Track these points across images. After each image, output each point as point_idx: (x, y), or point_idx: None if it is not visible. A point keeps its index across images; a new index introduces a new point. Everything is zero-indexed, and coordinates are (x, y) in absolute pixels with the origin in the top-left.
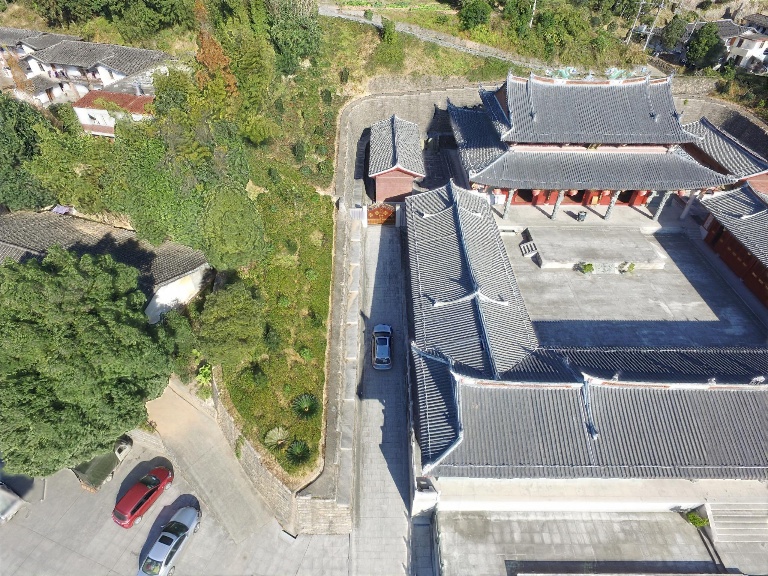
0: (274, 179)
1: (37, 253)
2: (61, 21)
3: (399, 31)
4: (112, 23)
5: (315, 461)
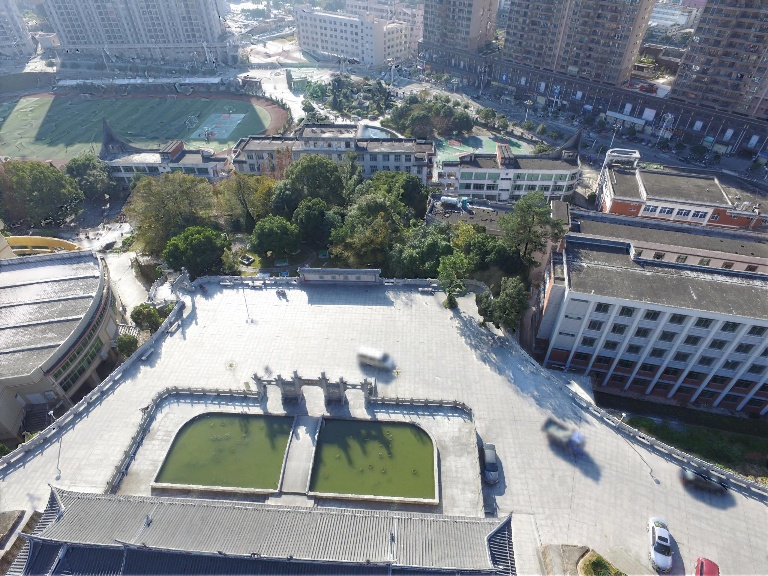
0: None
1: None
2: None
3: None
4: None
5: (586, 572)
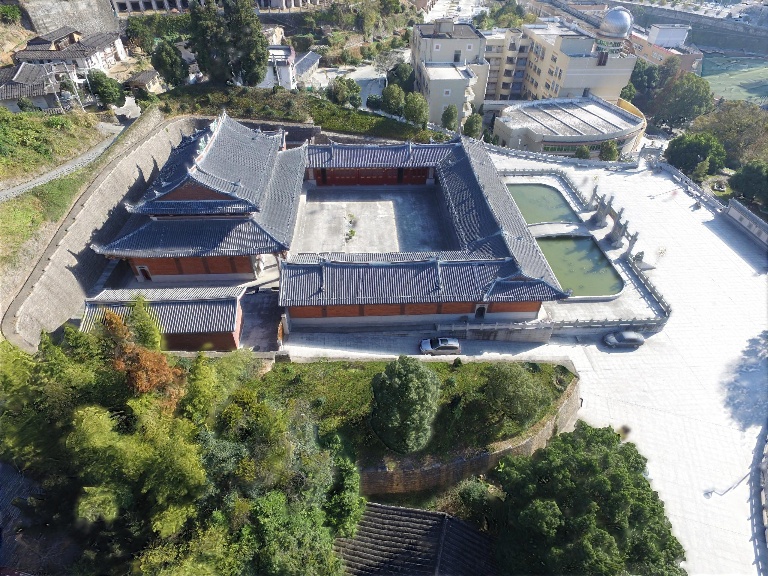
0: None
1: None
2: None
3: None
4: None
5: None
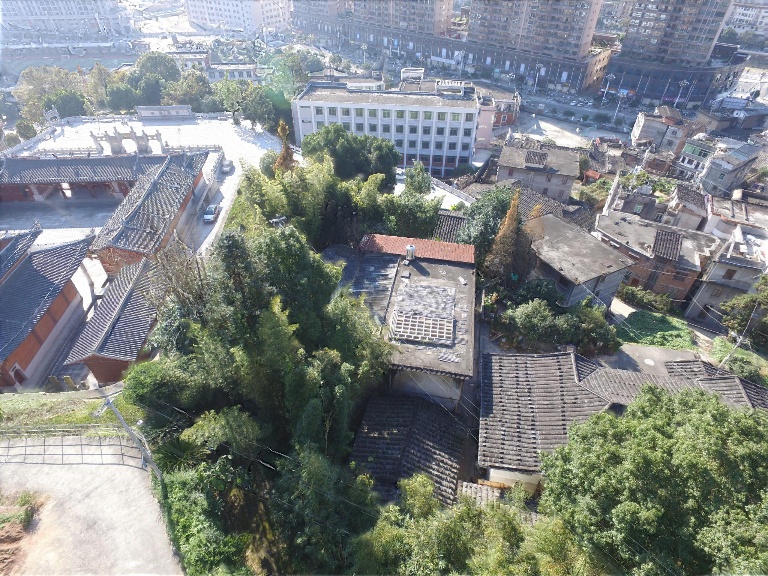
0: None
1: None
2: None
3: None
4: None
5: None
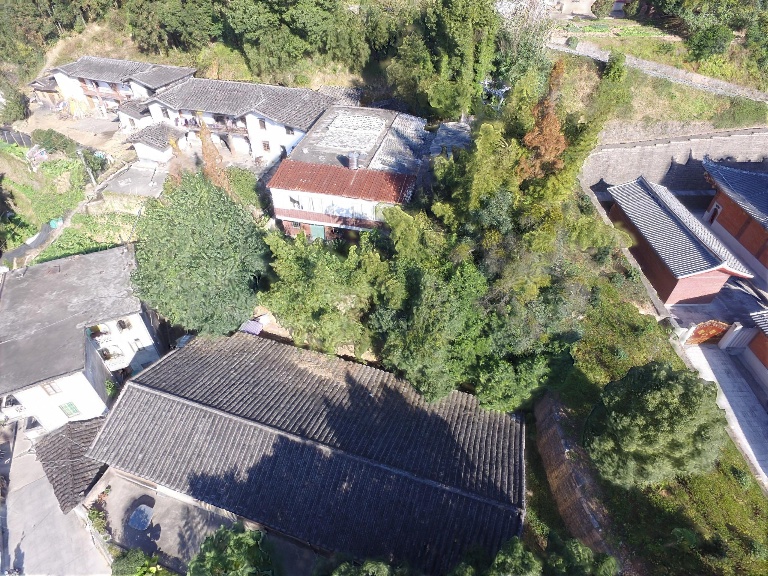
0: (595, 301)
1: (298, 439)
2: (159, 46)
3: None
4: (235, 51)
5: None
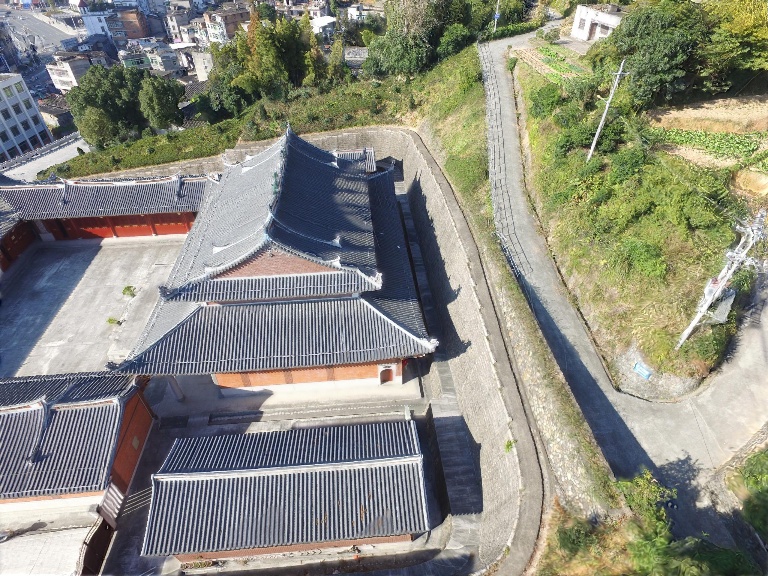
0: None
1: None
2: None
3: (493, 88)
4: None
5: None
